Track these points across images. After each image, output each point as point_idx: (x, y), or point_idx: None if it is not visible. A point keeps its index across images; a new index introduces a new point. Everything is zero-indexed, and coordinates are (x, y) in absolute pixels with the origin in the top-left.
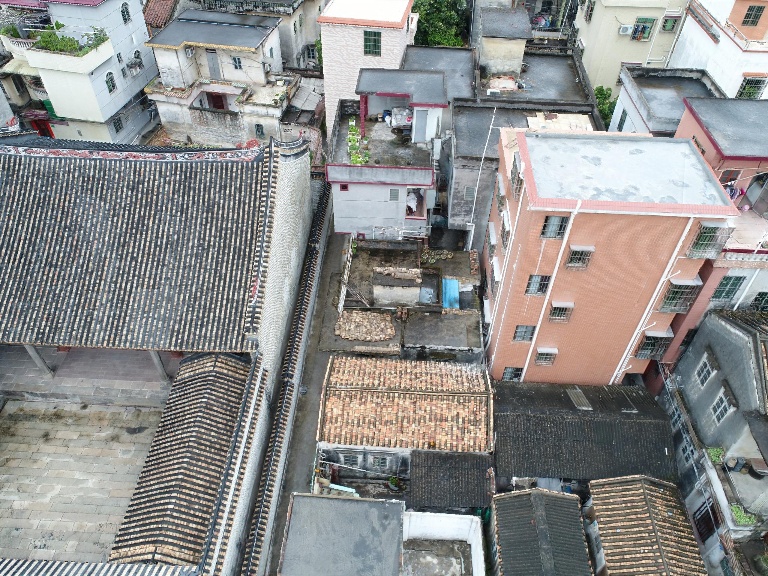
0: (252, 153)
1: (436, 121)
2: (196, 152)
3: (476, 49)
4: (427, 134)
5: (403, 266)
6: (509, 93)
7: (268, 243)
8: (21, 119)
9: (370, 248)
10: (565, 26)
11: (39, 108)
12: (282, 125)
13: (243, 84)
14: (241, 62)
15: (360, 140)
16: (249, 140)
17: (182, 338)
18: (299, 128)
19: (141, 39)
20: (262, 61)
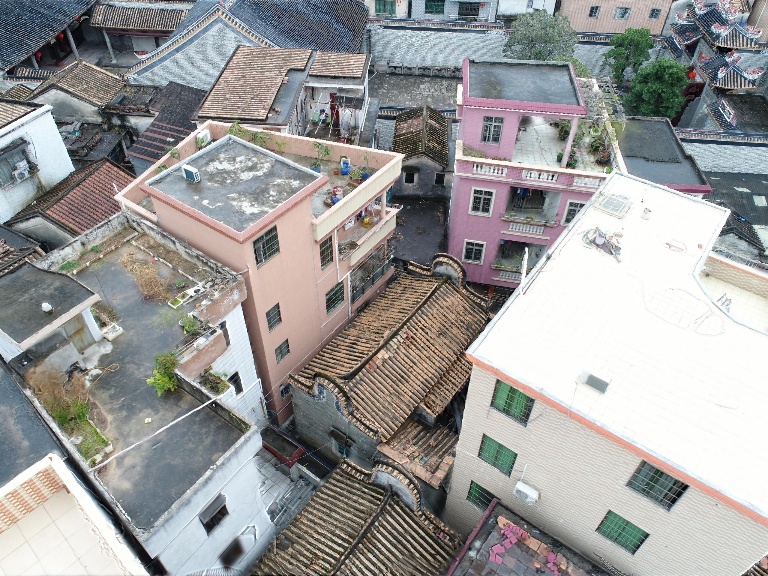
0: None
1: None
2: None
3: None
4: None
5: None
6: None
7: None
8: None
9: None
10: None
11: None
12: None
13: None
14: None
15: None
16: None
17: (84, 2)
18: None
19: None
20: None
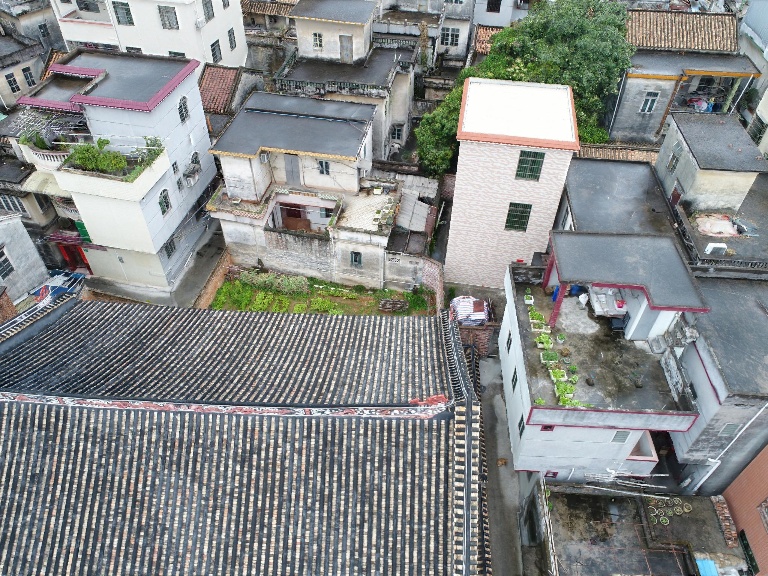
0: (433, 410)
1: (672, 317)
2: (344, 407)
3: (657, 164)
4: (652, 331)
5: (623, 530)
6: (729, 242)
7: (473, 575)
8: (45, 243)
9: (566, 493)
10: (732, 111)
11: (68, 227)
12: (388, 254)
13: (333, 196)
14: (329, 166)
15: (550, 335)
16: (433, 396)
17: None
18: (410, 258)
19: (199, 137)
20: (357, 166)
